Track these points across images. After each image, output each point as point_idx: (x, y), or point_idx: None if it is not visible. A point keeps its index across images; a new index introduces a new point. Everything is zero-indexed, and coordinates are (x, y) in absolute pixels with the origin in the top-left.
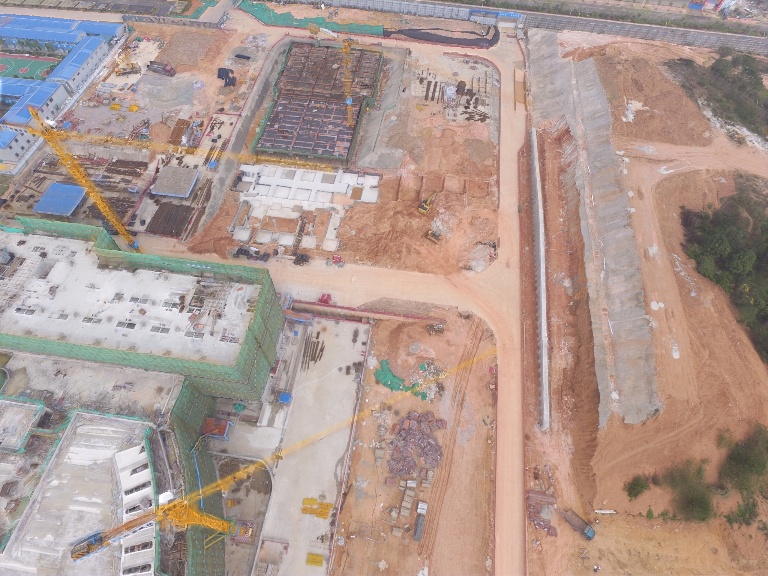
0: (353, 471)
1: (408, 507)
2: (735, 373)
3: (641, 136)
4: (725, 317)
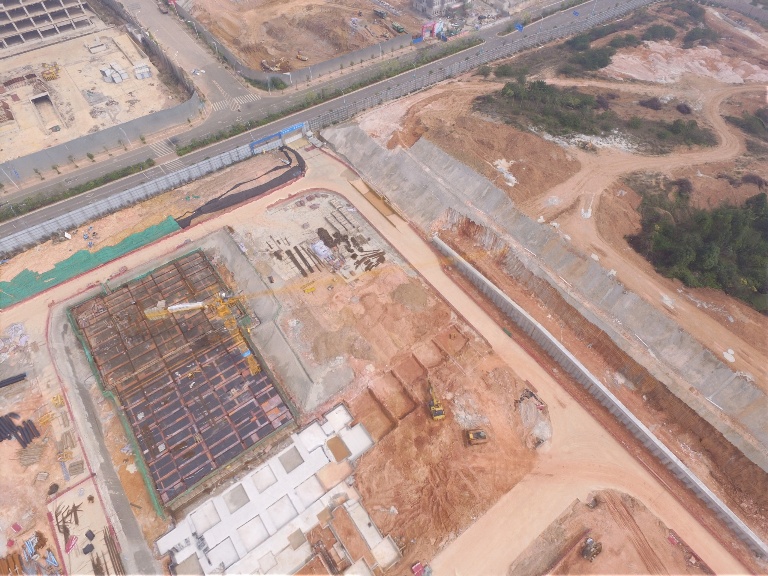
0: None
1: None
2: None
3: (537, 192)
4: (766, 322)
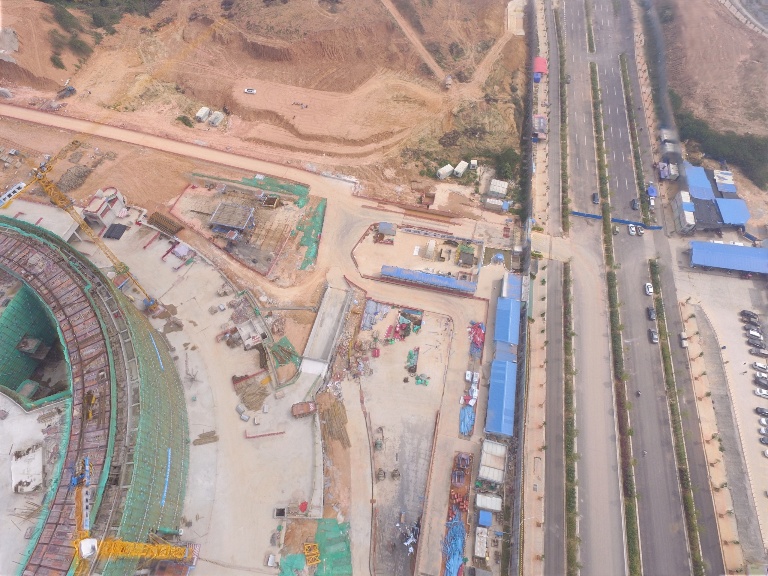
0: None
1: (7, 158)
2: (19, 3)
3: None
4: None
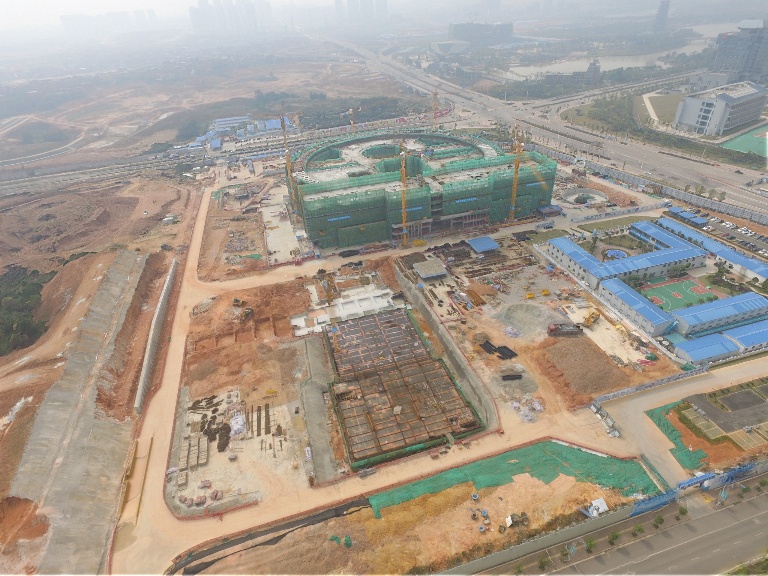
0: (262, 236)
1: None
2: None
3: None
4: None
